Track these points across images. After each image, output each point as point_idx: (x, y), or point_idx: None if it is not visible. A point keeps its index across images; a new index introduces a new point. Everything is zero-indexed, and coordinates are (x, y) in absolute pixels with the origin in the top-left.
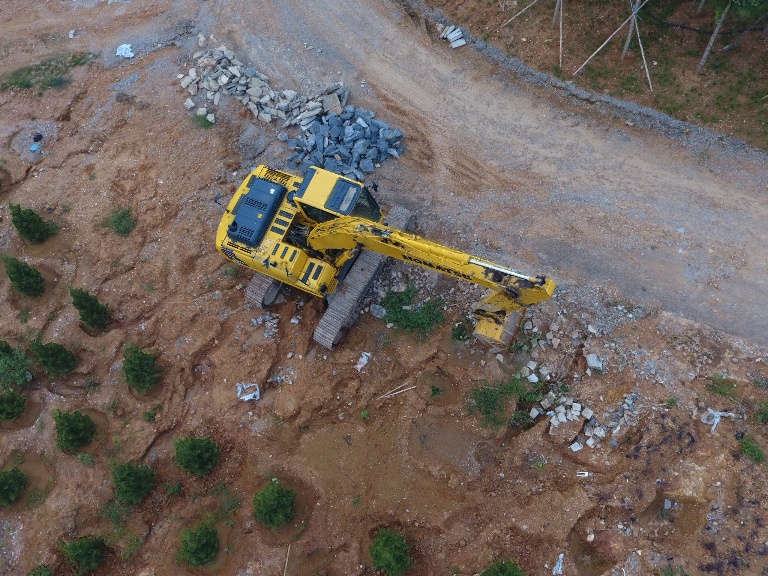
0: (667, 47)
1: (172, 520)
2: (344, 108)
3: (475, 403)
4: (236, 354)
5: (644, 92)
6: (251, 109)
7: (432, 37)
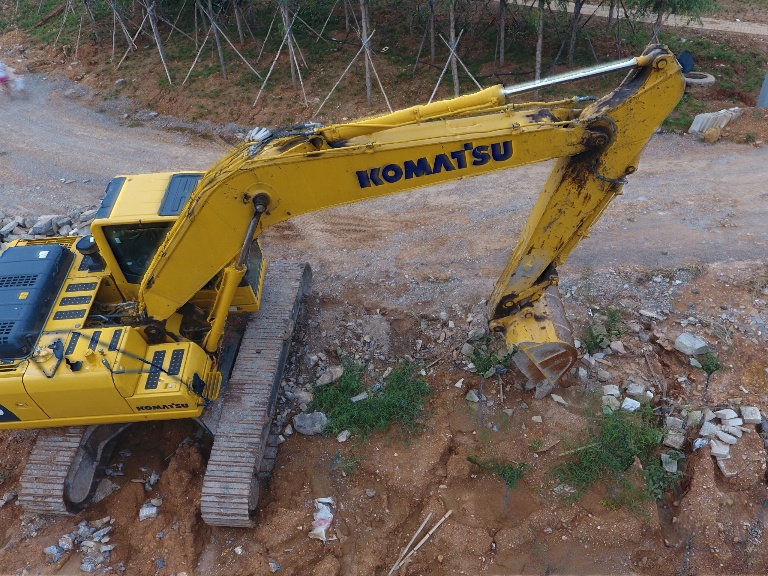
0: None
1: None
2: None
3: (571, 490)
4: None
5: None
6: None
7: (235, 145)
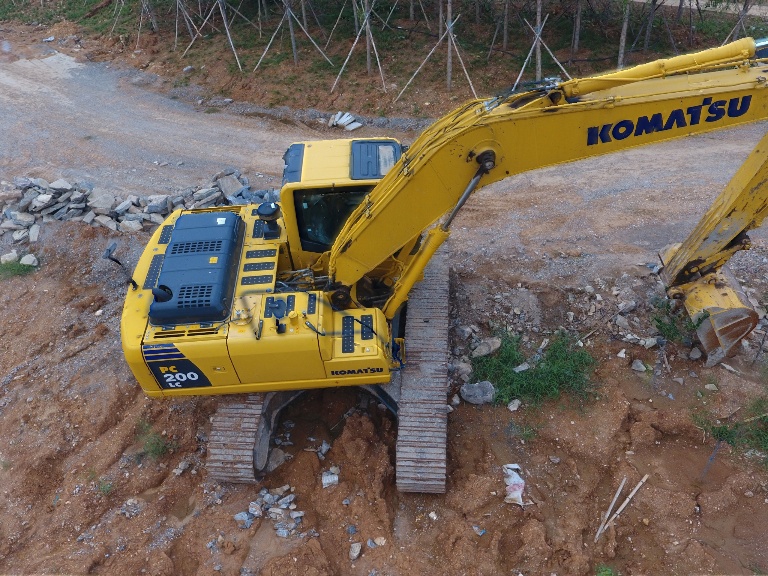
0: None
1: None
2: None
3: (762, 455)
4: None
5: None
6: (102, 223)
7: (318, 130)
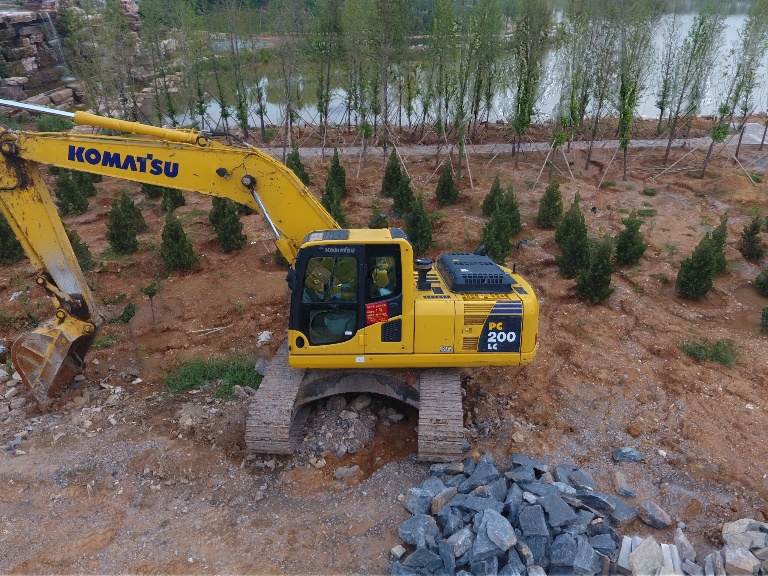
0: None
1: None
2: None
3: None
4: None
5: None
6: None
7: None
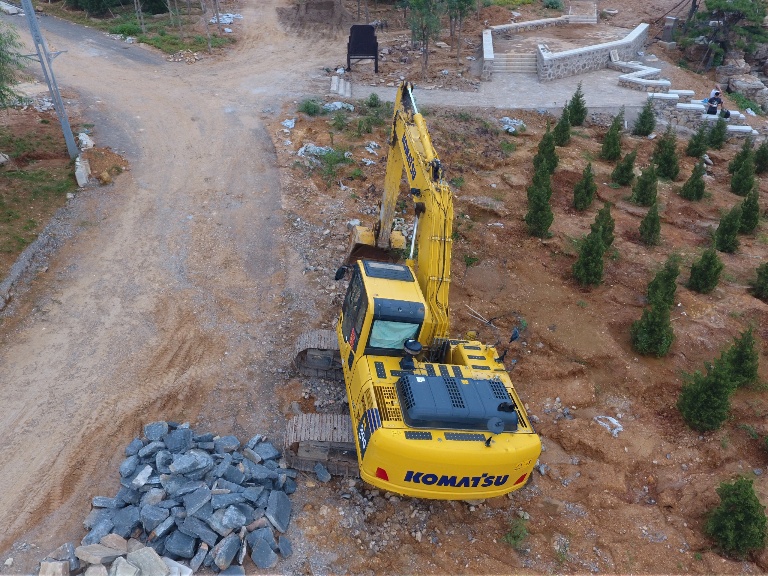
0: None
1: (760, 423)
2: None
3: None
4: (593, 462)
5: None
6: None
7: None
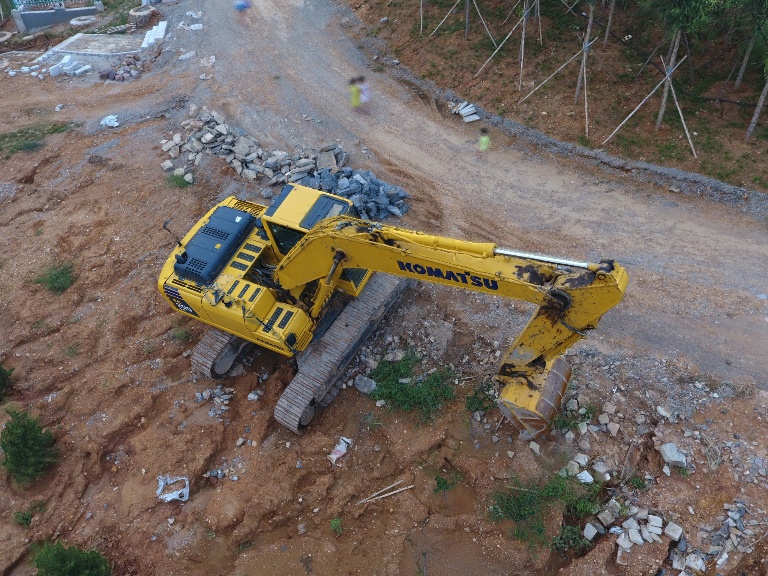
0: (706, 120)
1: None
2: (341, 168)
3: (500, 513)
4: (166, 437)
5: (687, 159)
6: (234, 166)
7: (443, 114)
